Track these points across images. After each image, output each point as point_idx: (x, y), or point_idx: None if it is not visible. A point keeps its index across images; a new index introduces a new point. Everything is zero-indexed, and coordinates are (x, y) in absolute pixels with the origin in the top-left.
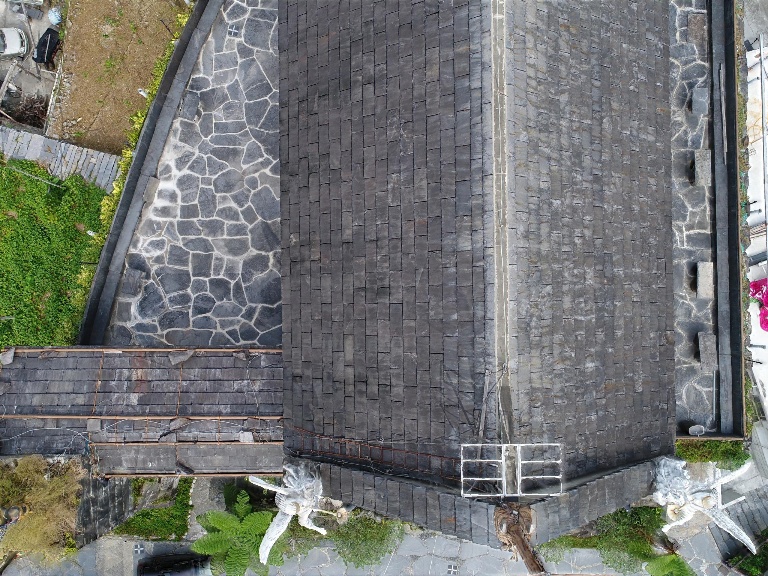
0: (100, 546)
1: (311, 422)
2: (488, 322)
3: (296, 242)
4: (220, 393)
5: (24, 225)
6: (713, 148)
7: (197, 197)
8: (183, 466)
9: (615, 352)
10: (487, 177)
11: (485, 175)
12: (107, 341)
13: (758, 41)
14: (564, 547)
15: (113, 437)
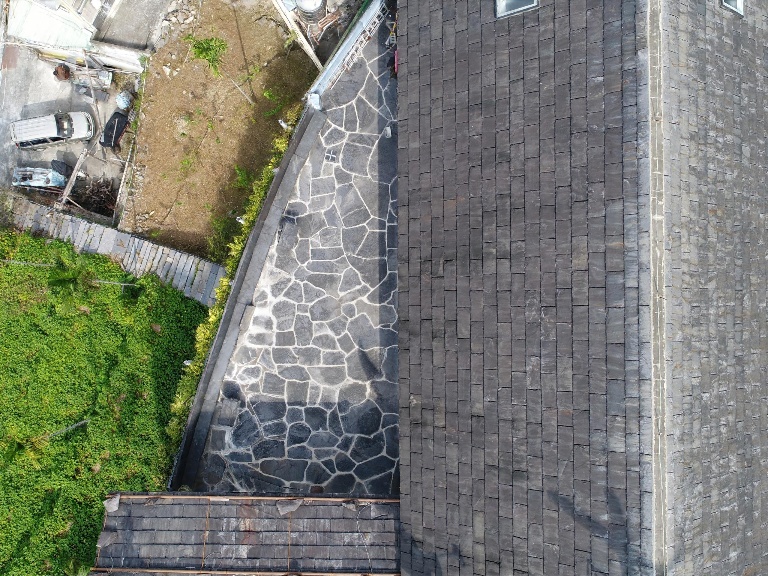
0: None
1: None
2: (645, 531)
3: (417, 404)
4: (331, 546)
5: (97, 321)
6: None
7: (293, 324)
8: None
9: (753, 534)
10: (644, 382)
11: (642, 379)
12: (201, 470)
13: None
14: None
15: None
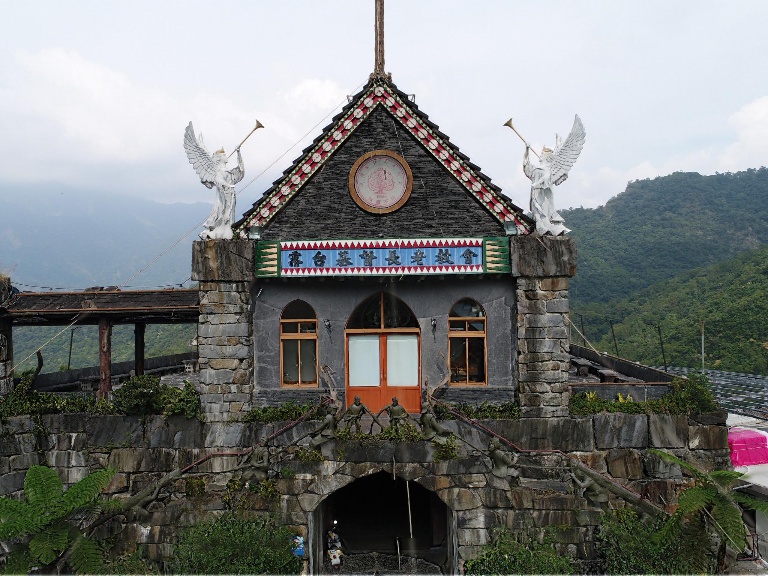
0: None
1: None
2: None
3: None
4: None
5: None
6: None
7: None
8: None
9: None
10: None
11: None
12: None
13: None
14: (554, 556)
15: None
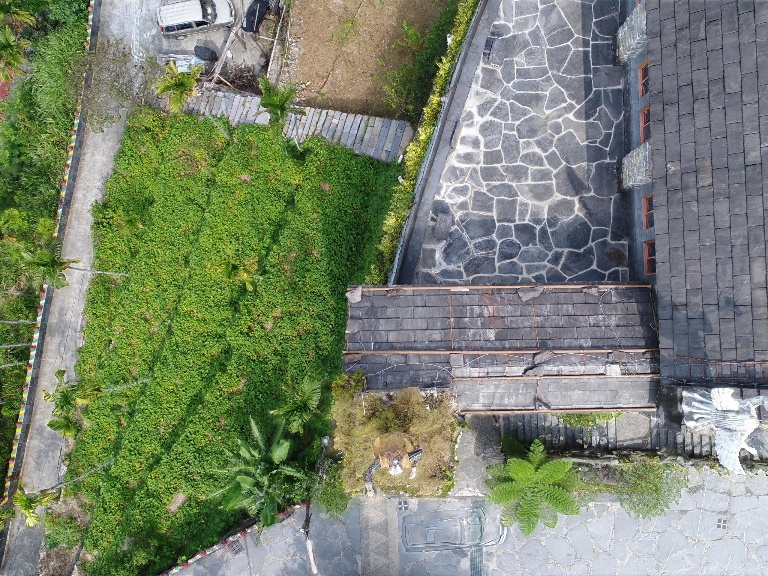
0: (364, 503)
1: (702, 349)
2: None
3: (676, 170)
4: (577, 328)
5: (259, 188)
6: None
7: (500, 143)
8: (541, 402)
9: None
10: None
11: None
12: None
13: None
14: None
15: (476, 372)
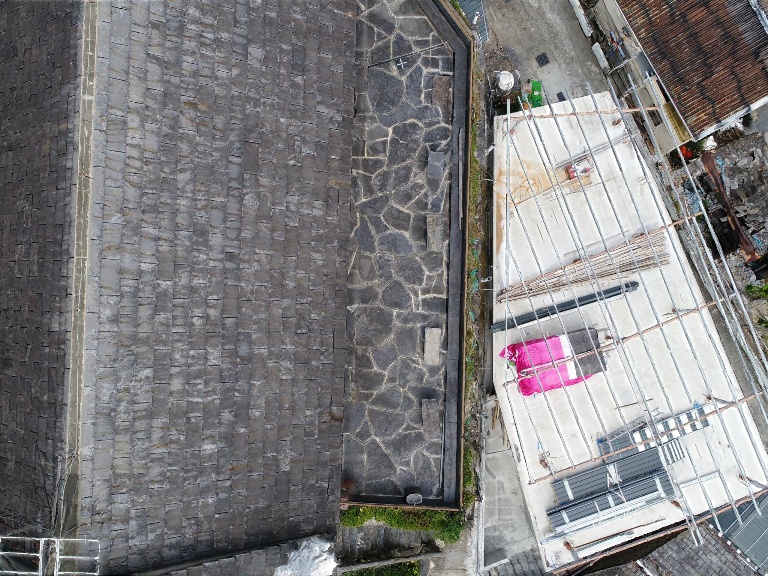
0: None
1: None
2: (63, 407)
3: None
4: None
5: None
6: (450, 213)
7: None
8: None
9: (250, 432)
10: (70, 260)
11: (69, 257)
12: None
13: (572, 94)
14: None
15: None
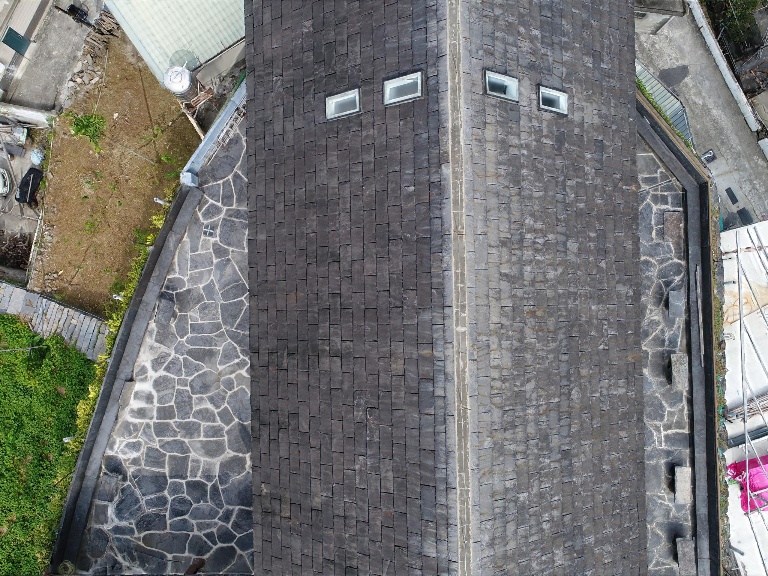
0: None
1: None
2: None
3: (267, 493)
4: None
5: (6, 382)
6: (690, 349)
7: (173, 398)
8: None
9: None
10: (451, 490)
11: (449, 487)
12: (84, 544)
13: (740, 188)
14: None
15: None
